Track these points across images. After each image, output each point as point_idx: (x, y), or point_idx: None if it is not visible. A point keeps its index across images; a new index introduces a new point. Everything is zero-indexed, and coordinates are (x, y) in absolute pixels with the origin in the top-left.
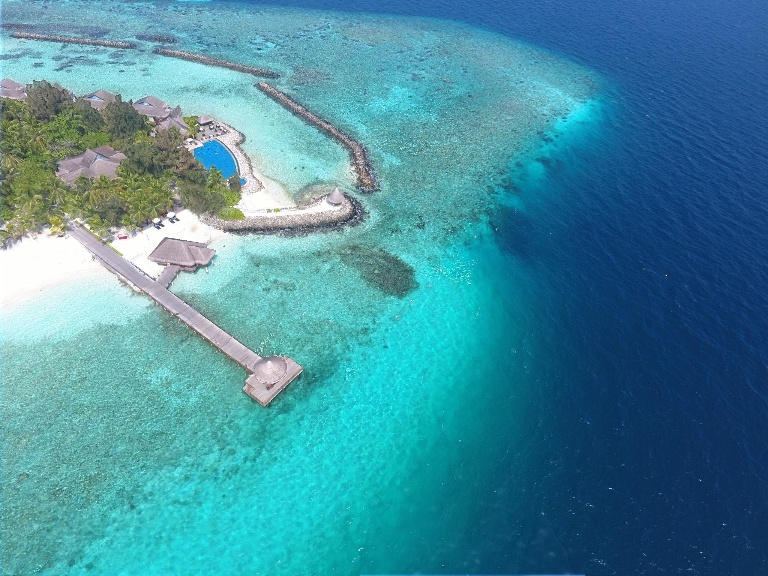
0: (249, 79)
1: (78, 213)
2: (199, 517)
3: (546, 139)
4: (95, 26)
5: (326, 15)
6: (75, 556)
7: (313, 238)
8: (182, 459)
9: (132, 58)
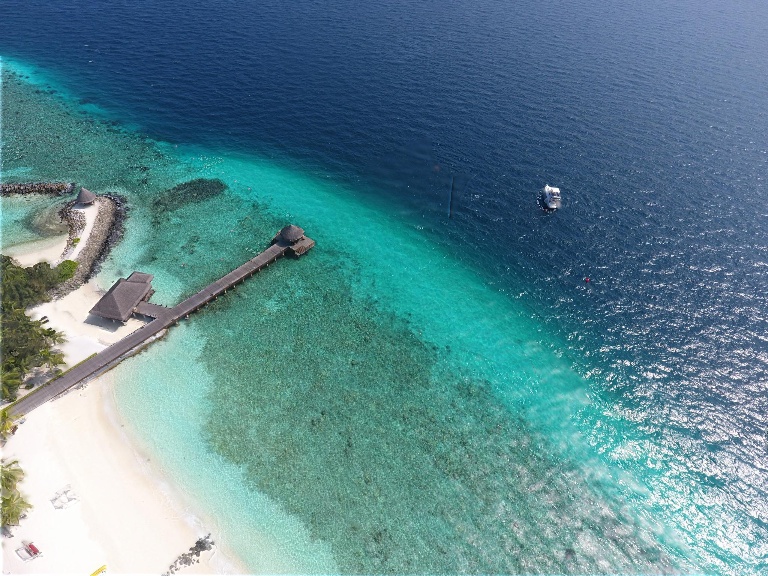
0: None
1: (4, 384)
2: (382, 274)
3: (51, 92)
4: None
5: None
6: (405, 322)
7: (131, 225)
8: (346, 284)
9: None
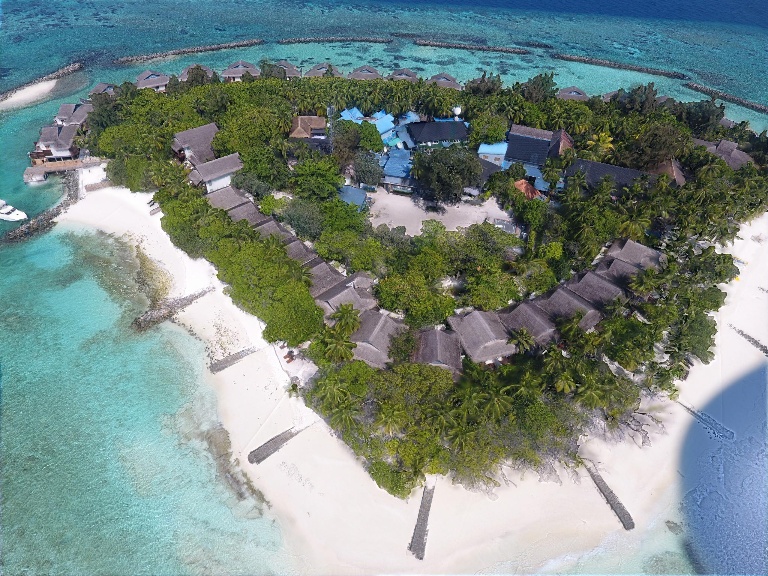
0: (669, 80)
1: None
2: None
3: None
4: (466, 34)
5: (633, 21)
6: None
7: None
8: None
9: (544, 63)
